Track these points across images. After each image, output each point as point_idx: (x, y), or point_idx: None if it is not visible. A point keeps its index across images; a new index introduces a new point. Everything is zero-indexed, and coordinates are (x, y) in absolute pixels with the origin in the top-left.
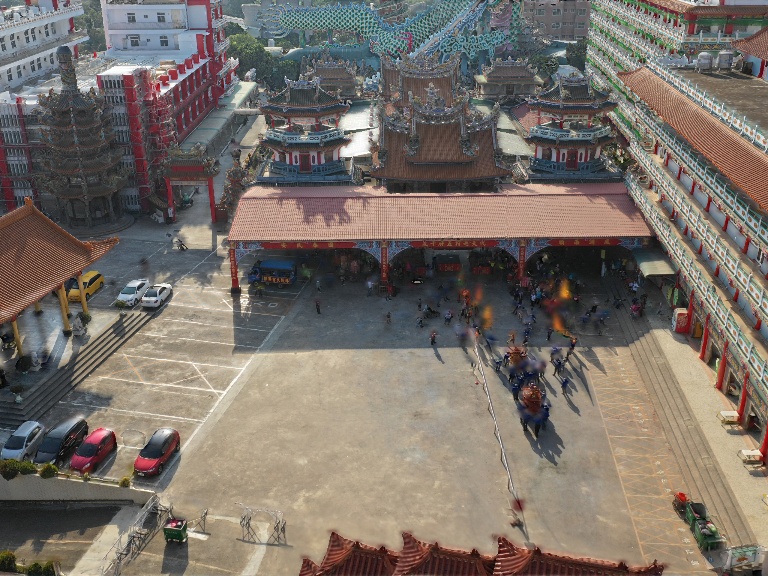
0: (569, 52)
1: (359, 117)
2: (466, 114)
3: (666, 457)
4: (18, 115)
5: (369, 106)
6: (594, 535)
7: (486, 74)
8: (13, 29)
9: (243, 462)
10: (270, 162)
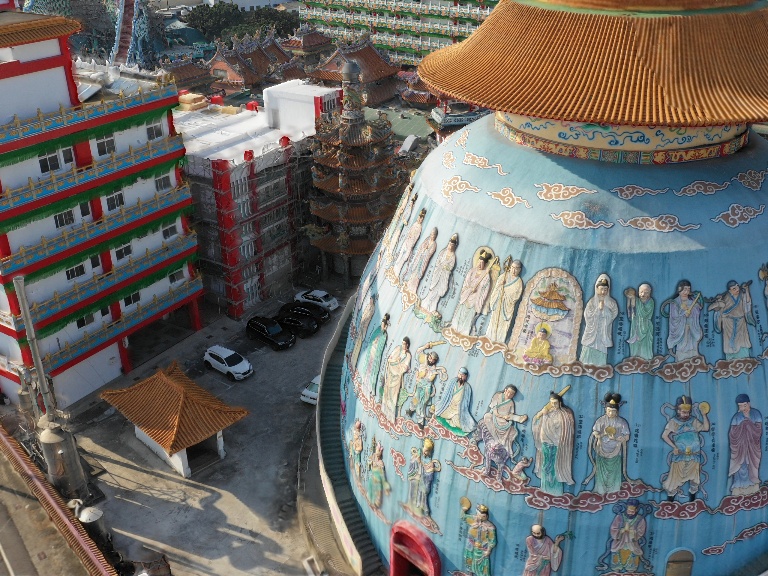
0: (191, 22)
1: None
2: None
3: None
4: (248, 176)
5: (252, 98)
6: None
7: (302, 45)
8: None
9: None
10: None
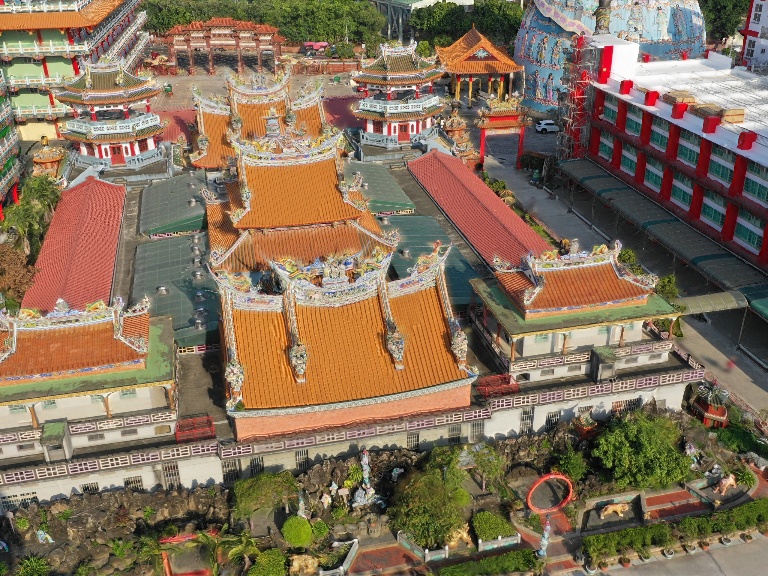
0: None
1: (427, 251)
2: (230, 94)
3: (167, 102)
4: None
5: None
6: (205, 90)
7: None
8: None
9: (330, 92)
10: (434, 126)
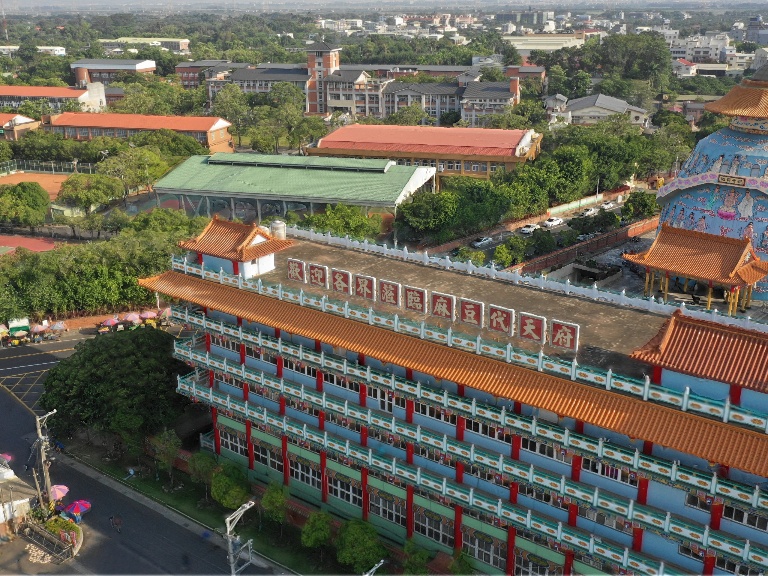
0: None
1: None
2: None
3: None
4: None
5: None
6: None
7: None
8: None
9: None
10: None
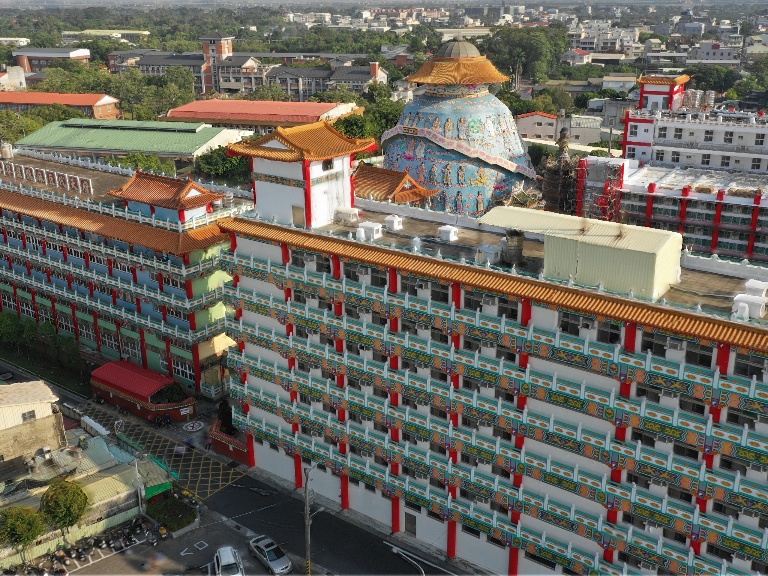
0: None
1: None
2: None
3: None
4: None
5: None
6: None
7: None
8: (702, 126)
9: None
10: None
